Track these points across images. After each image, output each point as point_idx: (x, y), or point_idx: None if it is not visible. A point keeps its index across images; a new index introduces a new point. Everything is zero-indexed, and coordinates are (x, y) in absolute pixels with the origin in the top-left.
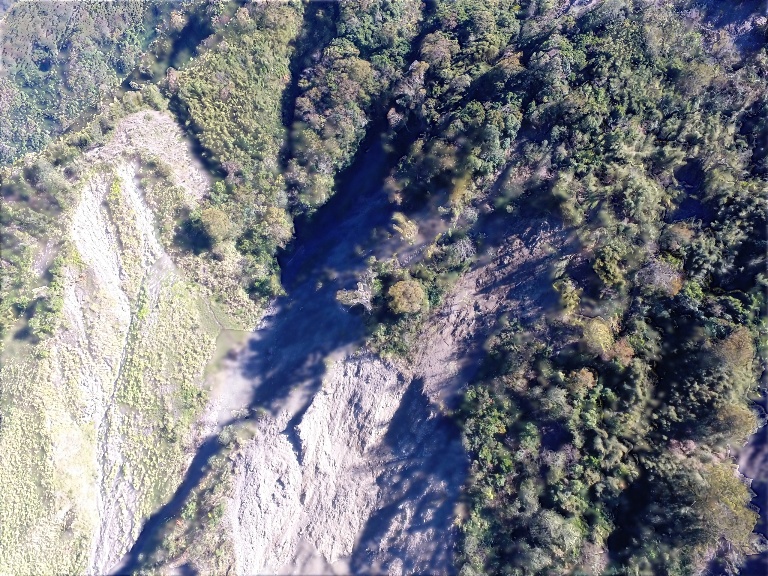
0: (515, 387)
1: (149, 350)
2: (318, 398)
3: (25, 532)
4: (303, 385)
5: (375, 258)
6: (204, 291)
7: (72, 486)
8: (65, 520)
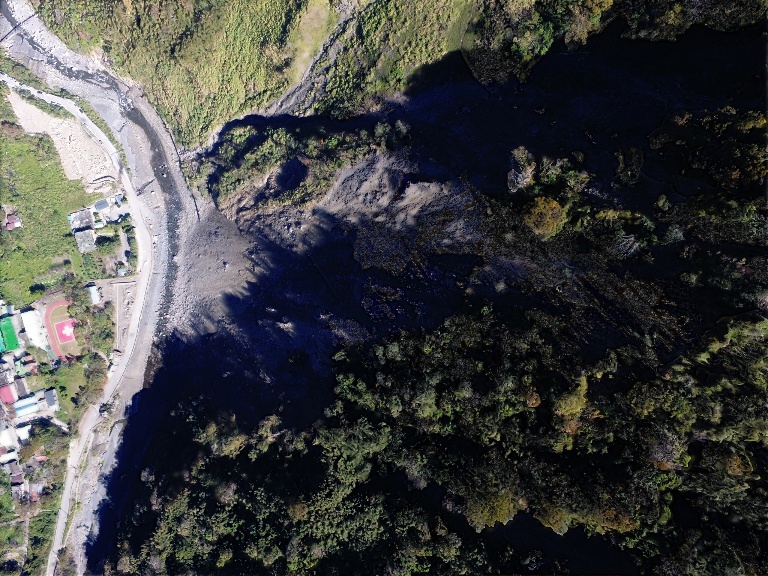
0: (503, 343)
1: (404, 7)
2: (436, 185)
3: (265, 43)
4: (441, 165)
5: (581, 156)
6: (480, 2)
7: (299, 47)
8: (285, 61)
